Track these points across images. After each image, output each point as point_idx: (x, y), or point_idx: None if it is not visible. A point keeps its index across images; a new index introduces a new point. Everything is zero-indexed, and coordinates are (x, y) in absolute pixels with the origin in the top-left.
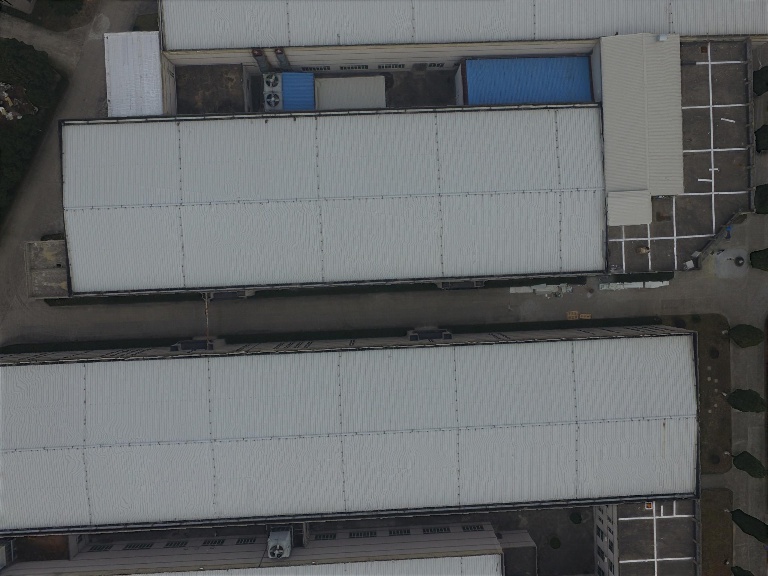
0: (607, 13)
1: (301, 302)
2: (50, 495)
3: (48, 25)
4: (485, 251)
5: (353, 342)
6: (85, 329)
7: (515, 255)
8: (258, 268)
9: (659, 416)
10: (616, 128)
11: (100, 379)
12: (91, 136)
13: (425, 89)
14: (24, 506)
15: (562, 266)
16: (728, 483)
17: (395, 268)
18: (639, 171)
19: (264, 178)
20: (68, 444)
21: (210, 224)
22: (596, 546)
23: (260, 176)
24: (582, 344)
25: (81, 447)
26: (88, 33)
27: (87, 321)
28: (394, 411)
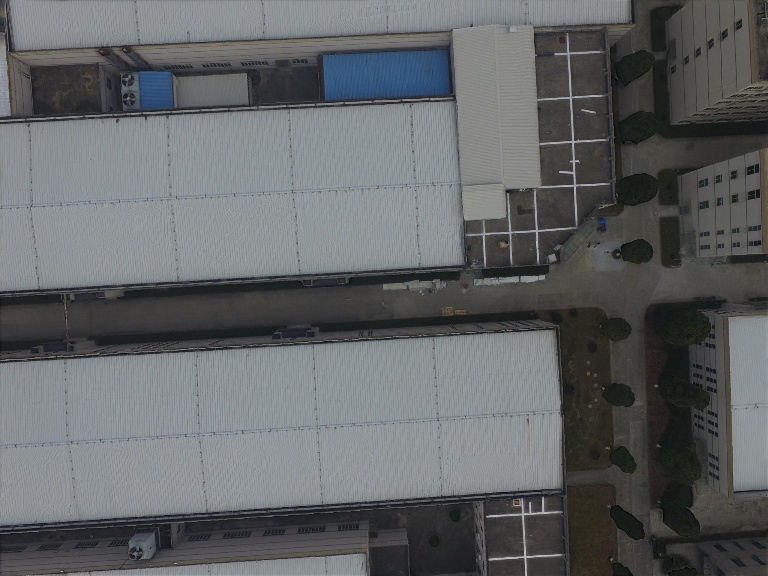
0: (461, 5)
1: (172, 302)
2: None
3: None
4: (344, 248)
5: (218, 342)
6: None
7: (375, 251)
8: (115, 269)
9: (522, 412)
10: (470, 121)
11: None
12: None
13: (292, 86)
14: None
15: (421, 262)
16: (611, 478)
17: (254, 266)
18: (493, 164)
19: (115, 178)
20: None
21: (67, 225)
22: (476, 544)
23: (111, 176)
24: (443, 340)
25: None
26: None
27: None
28: (252, 410)
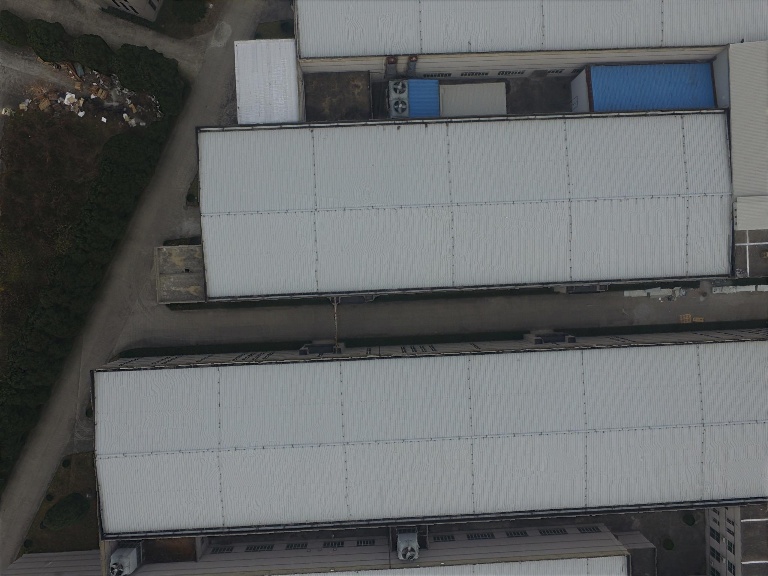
0: (733, 20)
1: (418, 306)
2: (184, 497)
3: (171, 33)
4: (611, 255)
5: (476, 346)
6: (206, 333)
7: (640, 259)
8: (388, 273)
9: None
10: (744, 134)
11: (234, 383)
12: (226, 143)
13: (541, 95)
14: (158, 508)
15: (688, 270)
16: None
17: (522, 272)
18: (767, 176)
19: (397, 184)
20: (203, 447)
21: (339, 229)
22: (709, 547)
23: (393, 182)
24: (707, 347)
25: (216, 450)
26: (210, 40)
27: (208, 325)
28: (523, 414)
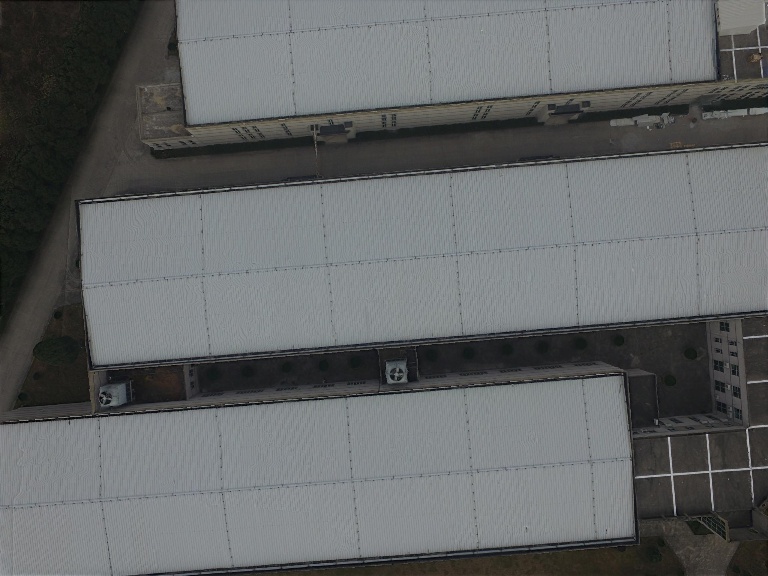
0: None
1: (401, 144)
2: (170, 326)
3: None
4: (592, 68)
5: None
6: (190, 180)
7: (622, 71)
8: (365, 96)
9: None
10: None
11: (216, 209)
12: None
13: None
14: (145, 338)
15: None
16: None
17: (501, 90)
18: None
19: (371, 2)
20: (187, 273)
21: (316, 57)
22: (713, 382)
23: (367, 0)
24: (697, 156)
25: (200, 276)
26: None
27: (192, 172)
28: (509, 229)
